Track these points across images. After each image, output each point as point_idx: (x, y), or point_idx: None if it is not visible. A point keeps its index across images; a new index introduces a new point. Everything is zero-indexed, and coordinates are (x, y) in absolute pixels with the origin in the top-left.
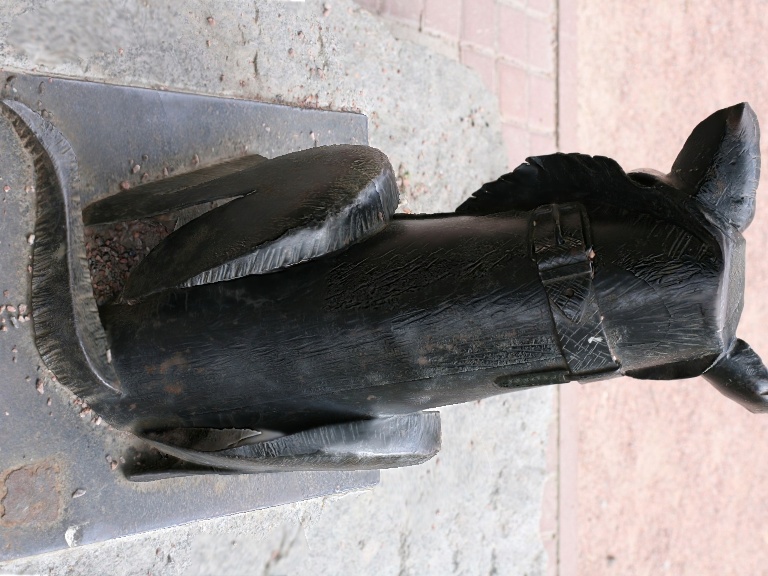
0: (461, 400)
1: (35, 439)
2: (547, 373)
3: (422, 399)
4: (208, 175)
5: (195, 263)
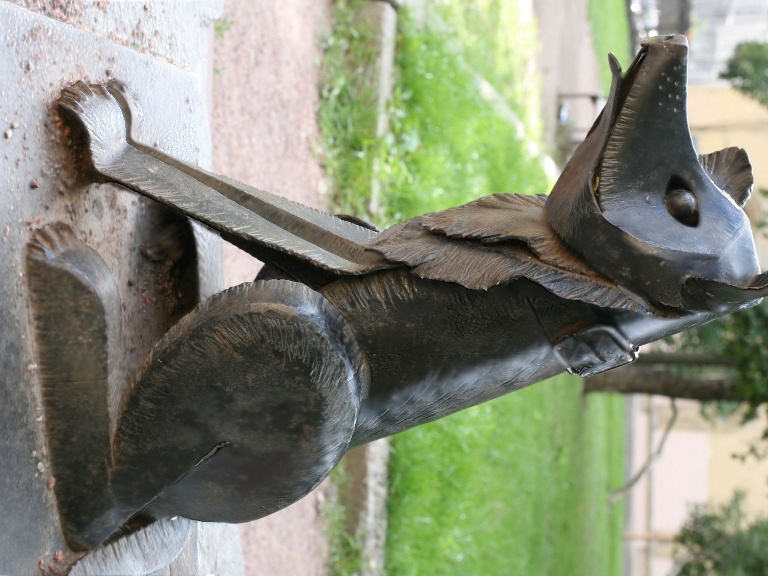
0: None
1: None
2: None
3: None
4: (79, 383)
5: (244, 513)
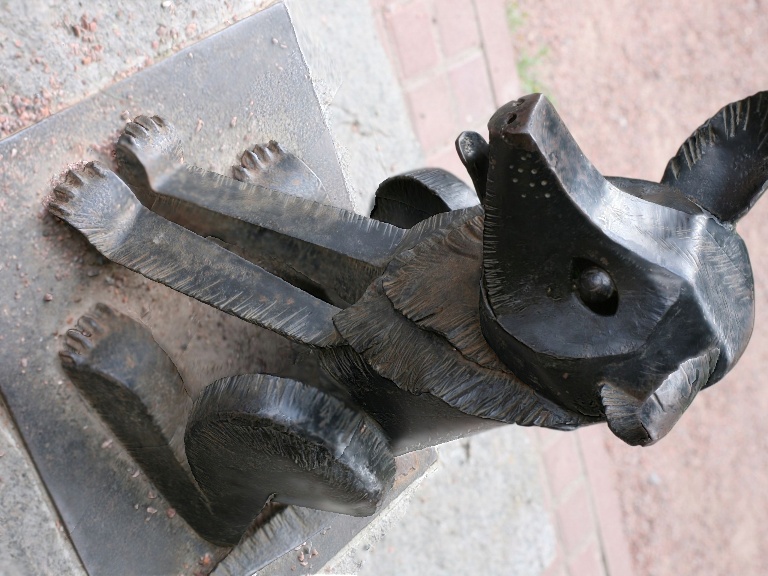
0: None
1: None
2: None
3: None
4: (150, 448)
5: None
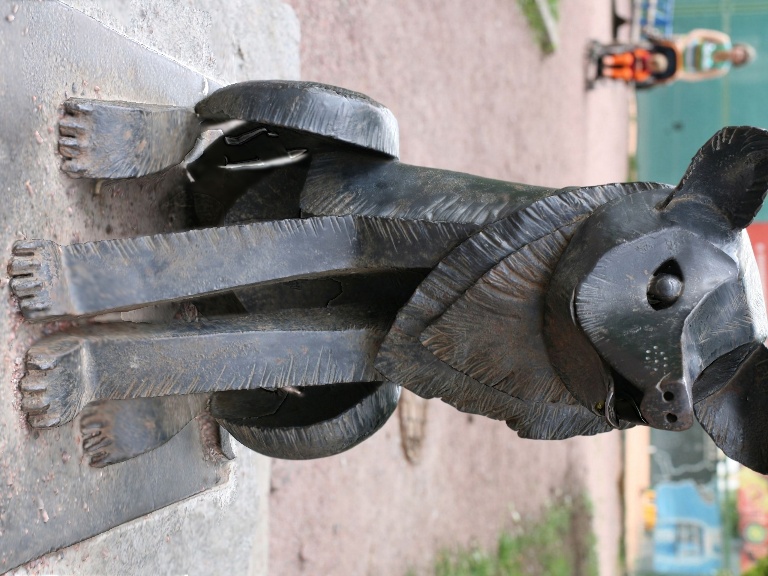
0: None
1: None
2: None
3: None
4: None
5: None
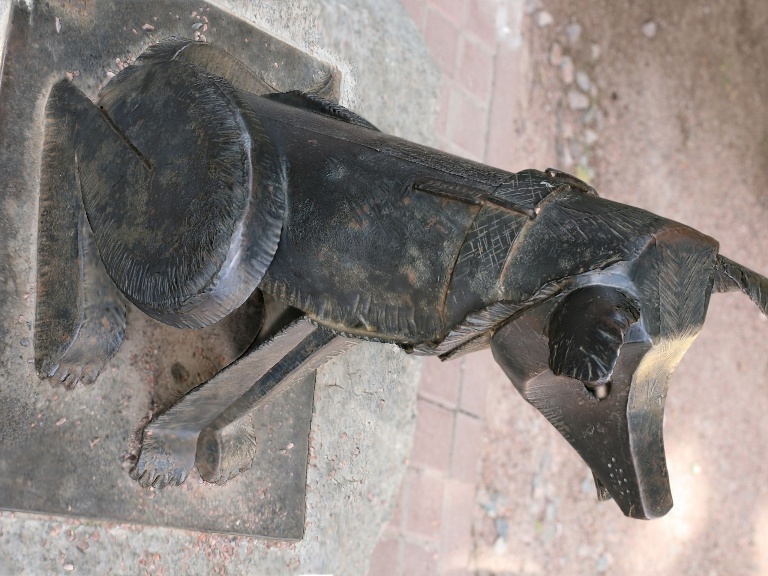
0: (353, 199)
1: (111, 3)
2: (471, 187)
3: (336, 172)
4: None
5: None
